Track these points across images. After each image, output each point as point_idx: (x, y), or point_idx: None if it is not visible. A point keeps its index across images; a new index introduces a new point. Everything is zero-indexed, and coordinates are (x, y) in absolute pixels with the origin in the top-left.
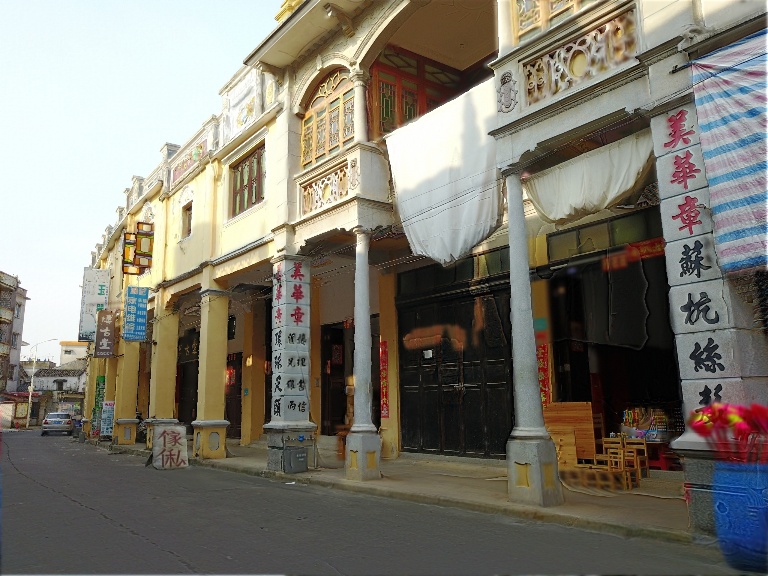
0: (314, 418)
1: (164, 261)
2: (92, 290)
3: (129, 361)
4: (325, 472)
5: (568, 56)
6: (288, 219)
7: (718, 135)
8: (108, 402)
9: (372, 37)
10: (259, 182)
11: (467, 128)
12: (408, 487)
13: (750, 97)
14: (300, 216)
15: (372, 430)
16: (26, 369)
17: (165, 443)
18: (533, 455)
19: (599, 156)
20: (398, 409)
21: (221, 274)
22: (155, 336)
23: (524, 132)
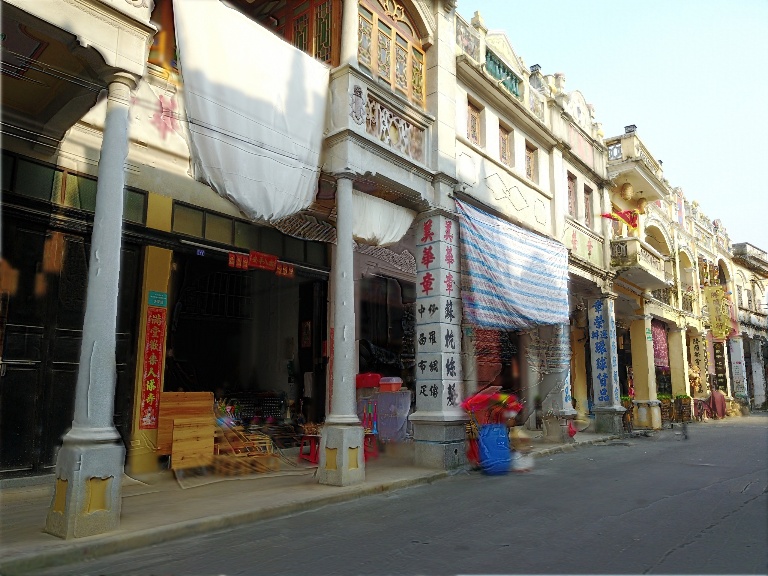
0: None
1: None
2: None
3: None
4: None
5: (390, 121)
6: None
7: (466, 249)
8: None
9: None
10: None
11: (293, 86)
12: None
13: None
14: None
15: None
16: None
17: None
18: (363, 438)
19: (388, 208)
20: None
21: None
22: None
23: (369, 154)
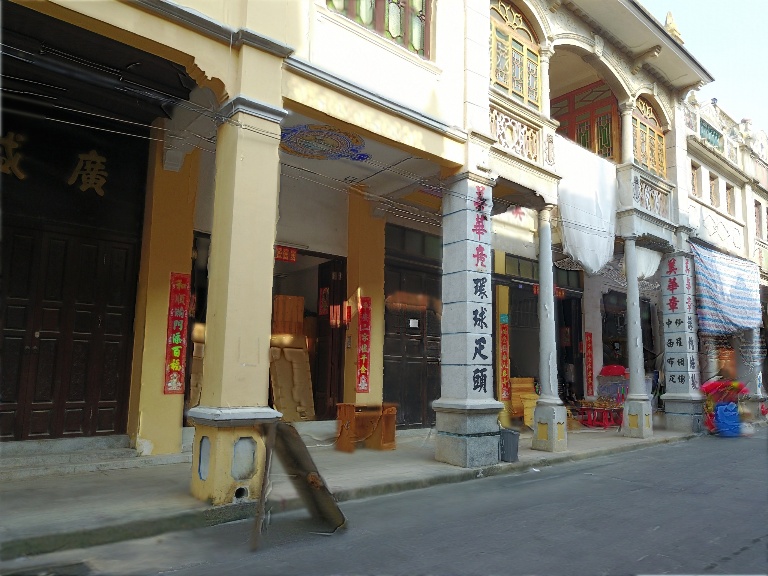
0: None
1: None
2: None
3: None
4: None
5: None
6: (491, 136)
7: None
8: None
9: (566, 39)
10: (409, 16)
11: (601, 184)
12: (594, 445)
13: (702, 269)
14: None
15: None
16: None
17: None
18: (651, 409)
19: None
20: None
21: (309, 101)
22: None
23: None
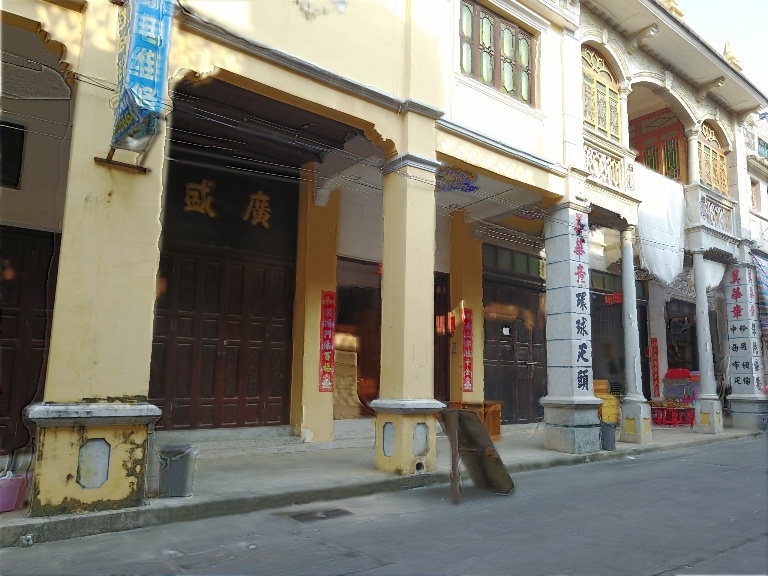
0: None
1: None
2: None
3: None
4: None
5: None
6: None
7: None
8: None
9: None
10: None
11: None
12: (674, 439)
13: None
14: None
15: None
16: None
17: None
18: (721, 408)
19: None
20: None
21: (452, 152)
22: None
23: None
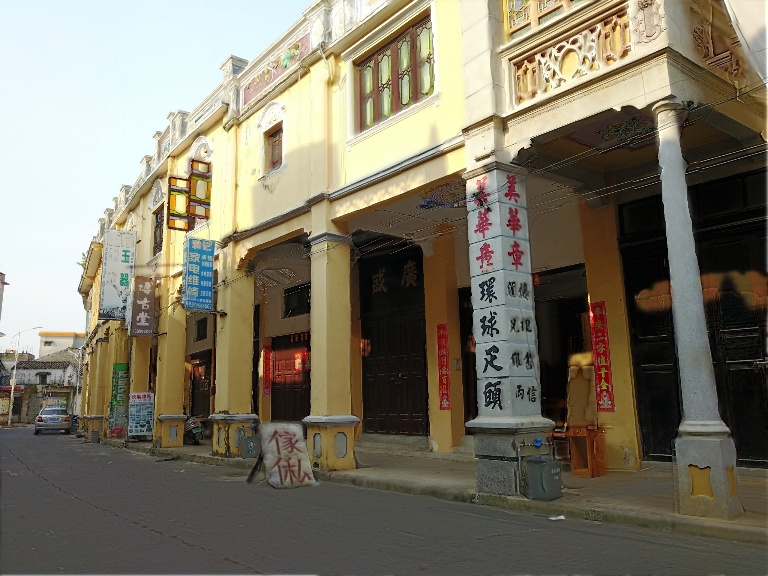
0: (456, 412)
1: (235, 206)
2: (114, 256)
3: (173, 341)
4: (598, 498)
5: None
6: (496, 109)
7: None
8: (136, 394)
9: None
10: (416, 73)
11: None
12: None
13: None
14: (512, 106)
15: (729, 431)
16: (2, 362)
17: (279, 449)
18: None
19: None
20: (633, 398)
21: (346, 210)
22: (223, 305)
23: None
